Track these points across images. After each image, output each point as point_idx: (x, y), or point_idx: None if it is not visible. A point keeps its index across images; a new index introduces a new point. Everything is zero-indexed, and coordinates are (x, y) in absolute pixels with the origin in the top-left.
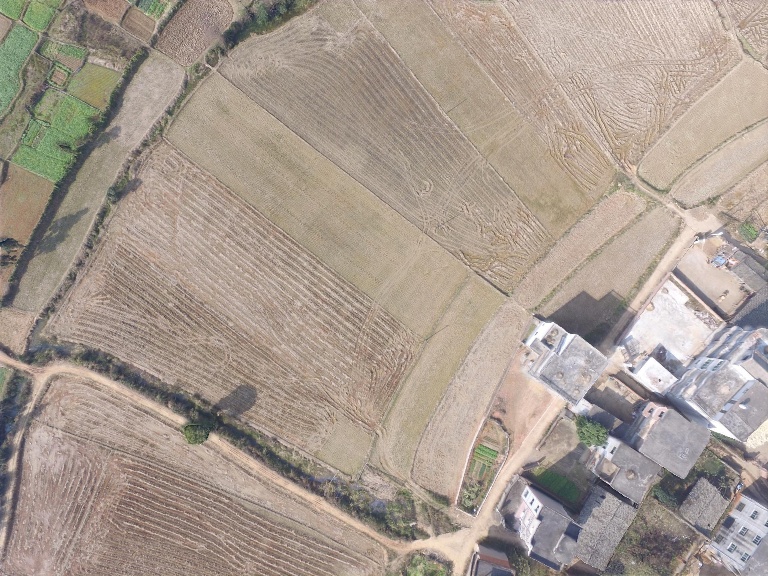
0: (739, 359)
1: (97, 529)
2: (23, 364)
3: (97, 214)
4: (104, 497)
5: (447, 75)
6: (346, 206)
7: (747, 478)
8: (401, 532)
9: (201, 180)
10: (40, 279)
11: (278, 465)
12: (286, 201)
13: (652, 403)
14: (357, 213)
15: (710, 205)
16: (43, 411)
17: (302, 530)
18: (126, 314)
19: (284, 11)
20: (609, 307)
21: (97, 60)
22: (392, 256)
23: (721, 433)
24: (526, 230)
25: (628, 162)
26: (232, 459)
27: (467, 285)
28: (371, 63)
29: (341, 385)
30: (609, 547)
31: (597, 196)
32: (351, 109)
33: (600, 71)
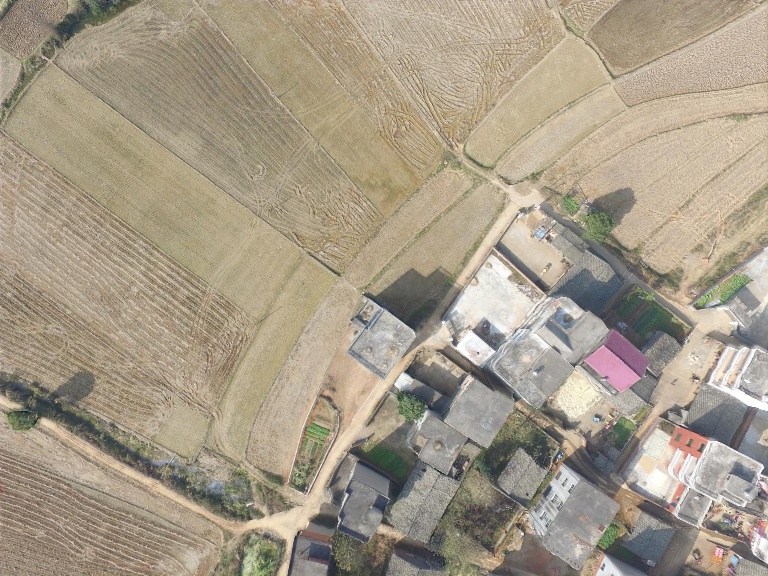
0: (538, 328)
1: None
2: None
3: None
4: None
5: (279, 60)
6: (181, 192)
7: (568, 447)
8: (237, 512)
9: (38, 170)
10: None
11: (115, 450)
12: (122, 189)
13: (469, 376)
14: (192, 199)
15: (533, 180)
16: None
17: (140, 514)
18: None
19: (117, 2)
20: (437, 283)
21: None
22: (227, 240)
23: None
24: (357, 210)
25: (456, 140)
26: (71, 445)
27: (300, 266)
28: (204, 51)
29: (177, 369)
30: (431, 519)
31: (426, 175)
32: (185, 96)
33: (428, 52)
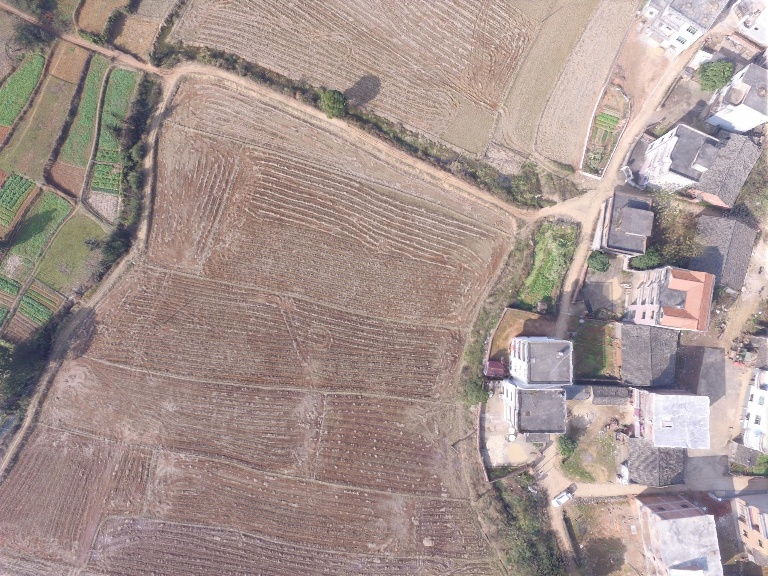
0: None
1: (234, 219)
2: (152, 67)
3: None
4: (239, 189)
5: None
6: None
7: None
8: (528, 203)
9: None
10: None
11: (406, 146)
12: None
13: None
14: None
15: None
16: (174, 112)
17: (432, 208)
18: (248, 16)
19: None
20: None
21: None
22: None
23: None
24: None
25: None
26: (360, 146)
27: None
28: None
29: (461, 70)
30: (735, 185)
31: None
32: None
33: None
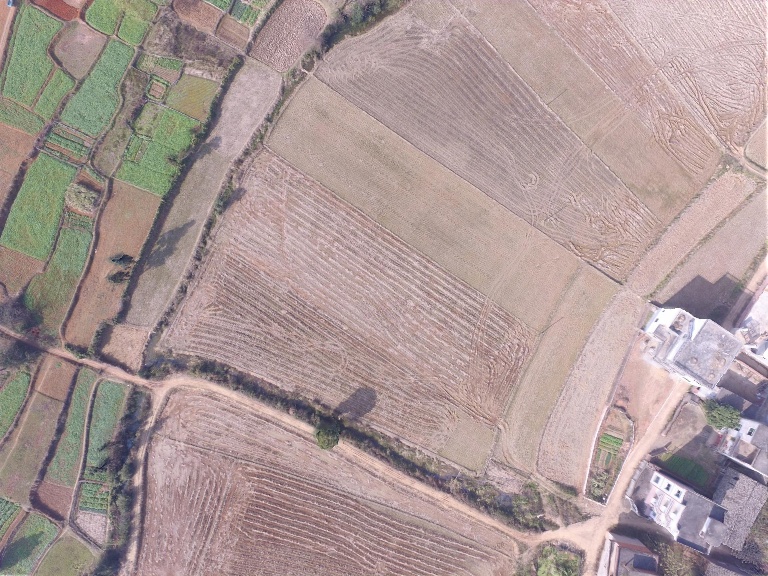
0: None
1: (226, 538)
2: (141, 379)
3: (204, 226)
4: (231, 506)
5: (546, 66)
6: (453, 204)
7: None
8: (530, 524)
9: (305, 186)
10: (151, 294)
11: (403, 465)
12: (392, 202)
13: None
14: (464, 210)
15: None
16: (164, 425)
17: (430, 528)
18: (240, 324)
19: (378, 11)
20: (725, 290)
21: (194, 71)
22: (502, 251)
23: None
24: (635, 218)
25: (734, 144)
26: (356, 462)
27: (580, 276)
28: (468, 59)
29: (460, 382)
30: (745, 527)
31: (705, 179)
32: (451, 106)
33: (700, 54)
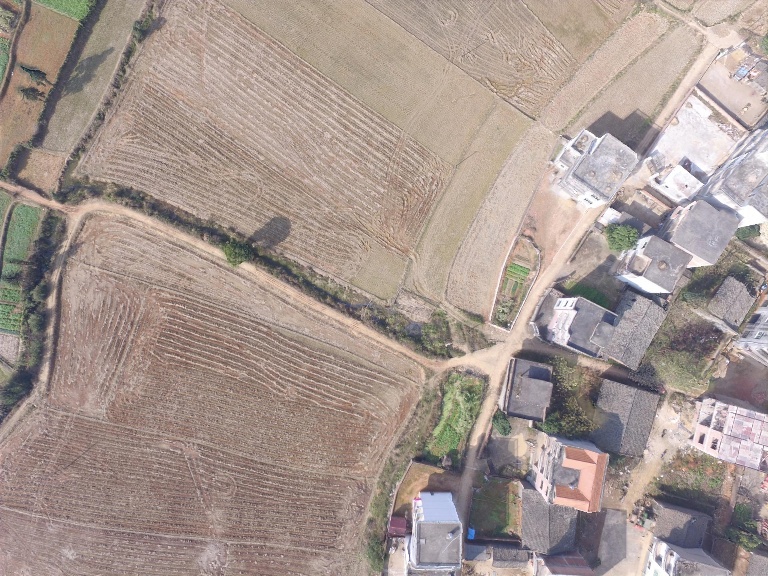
0: (766, 147)
1: (139, 361)
2: (57, 203)
3: (123, 53)
4: (144, 331)
5: None
6: (372, 38)
7: None
8: (437, 352)
9: (226, 17)
10: (69, 120)
11: (315, 292)
12: (312, 35)
13: (680, 206)
14: (383, 45)
15: (731, 21)
16: (79, 250)
17: (340, 354)
18: (157, 152)
19: None
20: (634, 126)
21: None
22: (419, 86)
23: (748, 224)
24: (551, 55)
25: None
26: (269, 289)
27: (494, 111)
28: None
29: (373, 213)
30: (640, 347)
31: (620, 19)
32: None
33: None
